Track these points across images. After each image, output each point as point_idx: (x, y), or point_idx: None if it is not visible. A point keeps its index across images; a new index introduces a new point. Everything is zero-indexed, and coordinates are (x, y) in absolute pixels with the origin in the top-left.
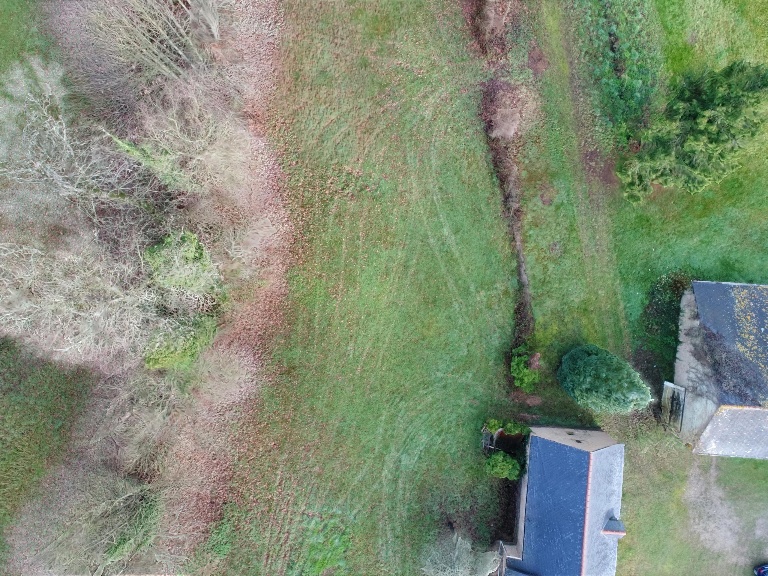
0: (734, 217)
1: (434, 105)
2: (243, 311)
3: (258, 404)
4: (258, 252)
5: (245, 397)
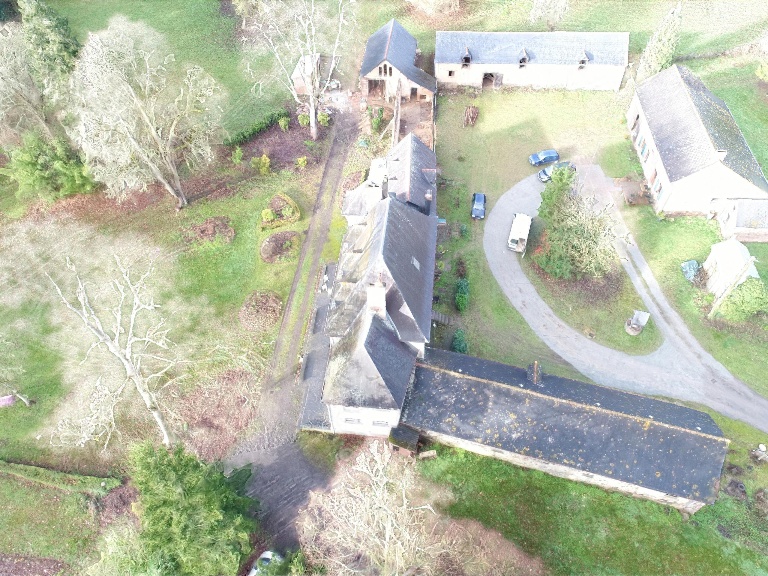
0: (767, 132)
1: (762, 31)
2: None
3: None
4: None
5: None
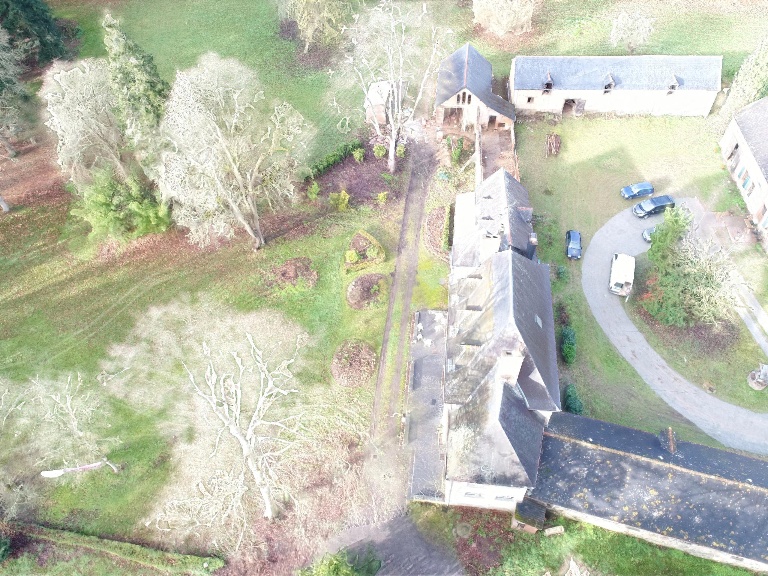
0: None
1: None
2: (709, 2)
3: (667, 6)
4: (740, 5)
5: (668, 3)
